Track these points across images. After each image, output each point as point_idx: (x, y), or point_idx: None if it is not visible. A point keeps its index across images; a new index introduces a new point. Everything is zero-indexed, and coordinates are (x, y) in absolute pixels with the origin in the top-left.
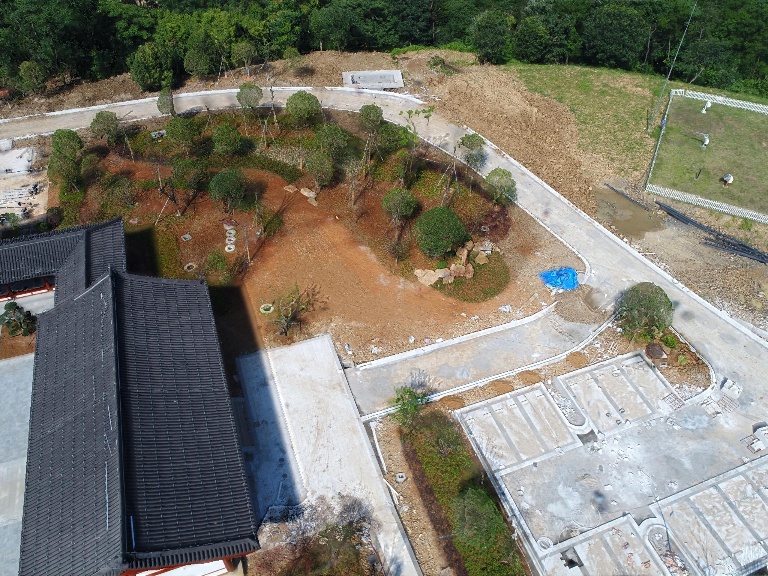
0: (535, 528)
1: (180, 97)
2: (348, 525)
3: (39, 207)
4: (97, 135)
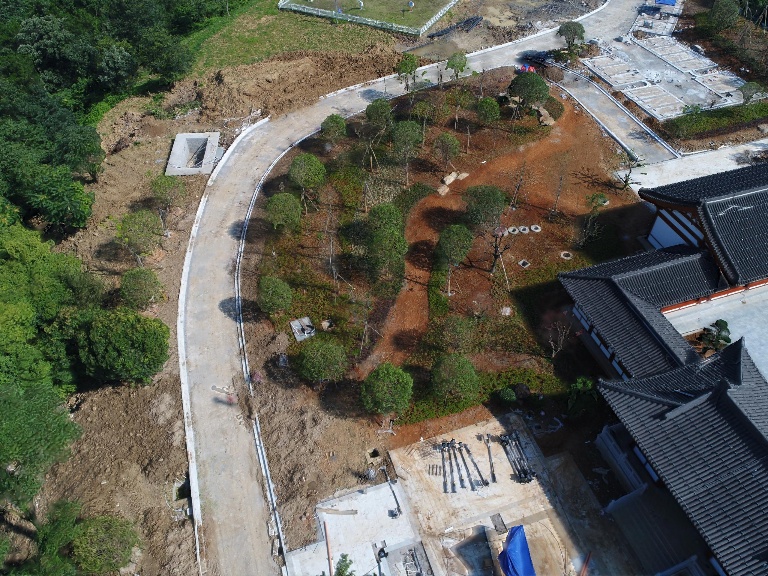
0: None
1: (184, 331)
2: (754, 162)
3: (485, 431)
4: (343, 371)
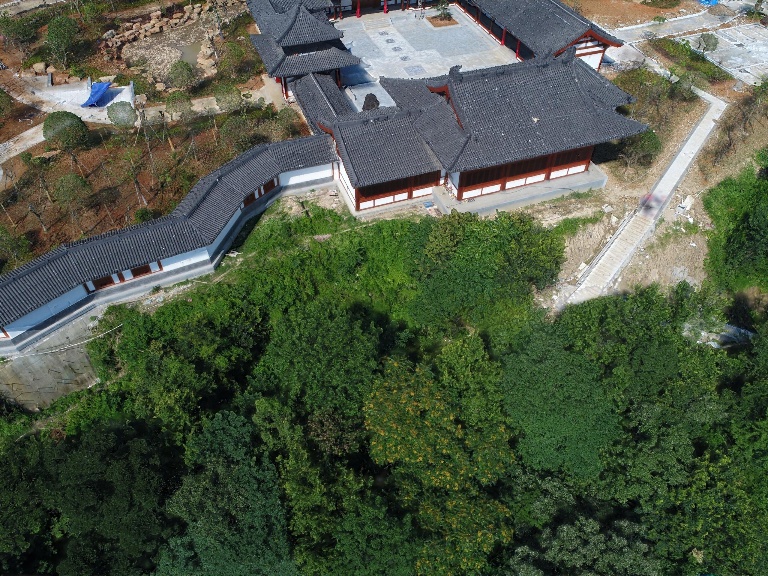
0: (724, 65)
1: None
2: None
3: None
4: None
